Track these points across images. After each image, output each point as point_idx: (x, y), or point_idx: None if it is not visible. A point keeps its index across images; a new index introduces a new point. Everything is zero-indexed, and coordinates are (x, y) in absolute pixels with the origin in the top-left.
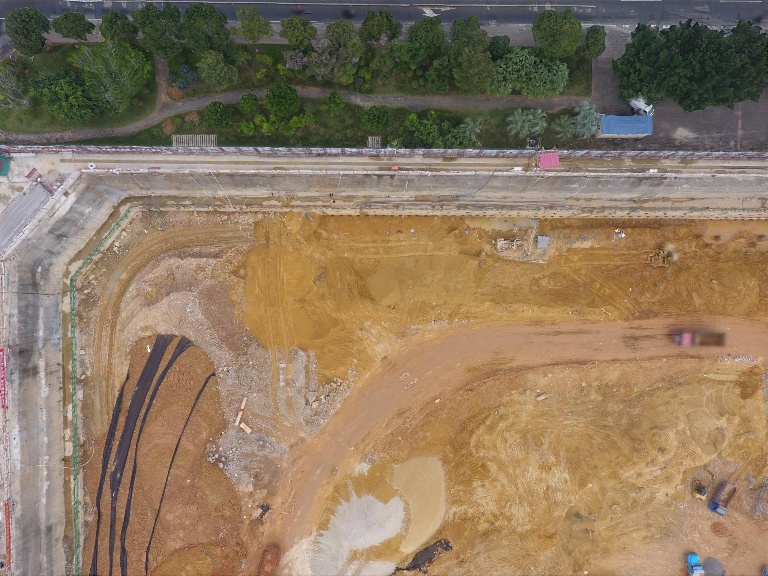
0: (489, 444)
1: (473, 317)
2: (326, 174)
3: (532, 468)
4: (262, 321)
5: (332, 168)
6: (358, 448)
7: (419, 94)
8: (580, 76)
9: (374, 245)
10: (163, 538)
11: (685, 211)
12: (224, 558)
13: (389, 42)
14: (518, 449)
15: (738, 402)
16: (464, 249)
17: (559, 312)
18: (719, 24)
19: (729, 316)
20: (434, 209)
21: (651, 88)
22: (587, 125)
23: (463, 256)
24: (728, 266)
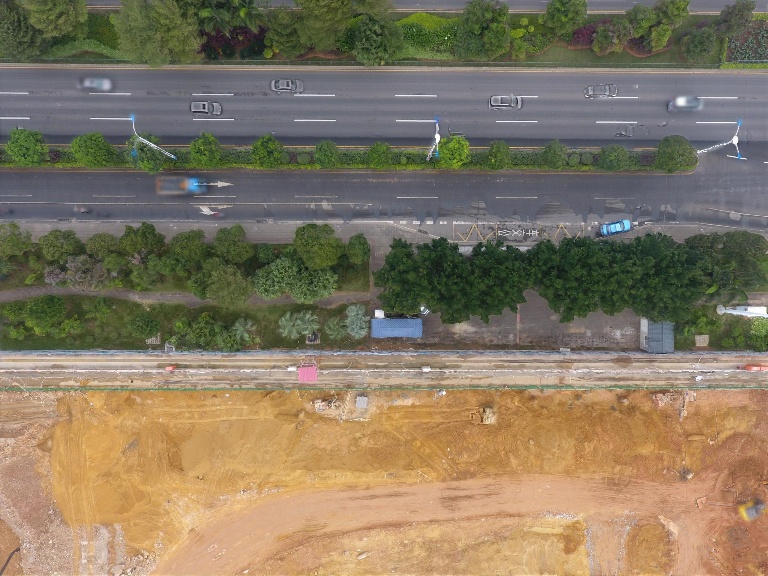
0: None
1: (283, 486)
2: (105, 371)
3: None
4: (64, 498)
5: (111, 365)
6: None
7: None
8: (354, 275)
9: (189, 410)
10: None
11: (483, 388)
12: None
13: (146, 258)
14: None
15: (561, 557)
16: (283, 409)
17: (373, 476)
18: (496, 220)
19: (548, 474)
20: (232, 388)
21: (404, 305)
22: (355, 330)
23: (278, 420)
24: (548, 423)
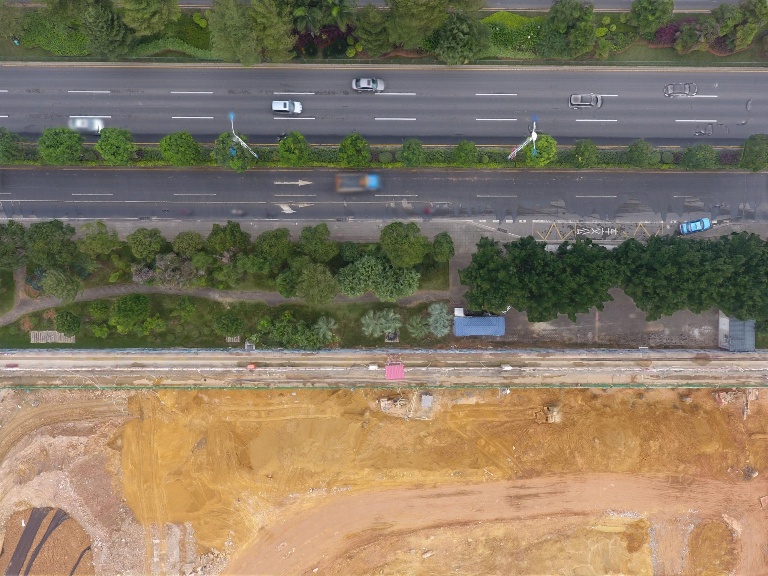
0: None
1: (352, 484)
2: None
3: None
4: (136, 497)
5: (191, 363)
6: None
7: (277, 290)
8: (435, 274)
9: (256, 408)
10: None
11: (555, 386)
12: None
13: (234, 257)
14: None
15: (625, 556)
16: (348, 408)
17: (440, 475)
18: (575, 218)
19: (613, 473)
20: (305, 387)
21: (493, 303)
22: (438, 328)
23: (345, 418)
24: (612, 422)
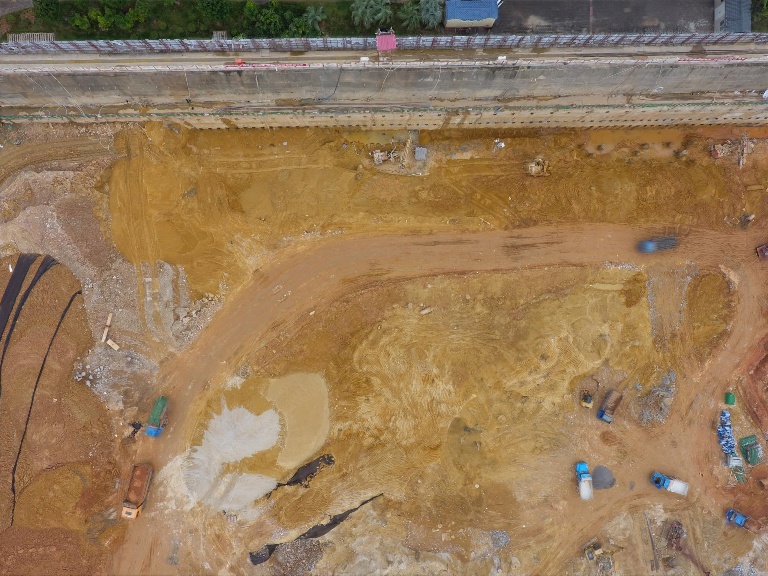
0: (372, 359)
1: (347, 228)
2: (170, 71)
3: (416, 381)
4: (125, 235)
5: (176, 65)
6: (230, 362)
7: None
8: None
9: (246, 159)
10: (30, 458)
11: (550, 109)
12: (95, 477)
13: None
14: (401, 362)
15: (623, 310)
16: (341, 163)
17: (436, 222)
18: None
19: (610, 223)
20: (296, 113)
21: None
22: (430, 10)
23: (338, 168)
24: (608, 173)
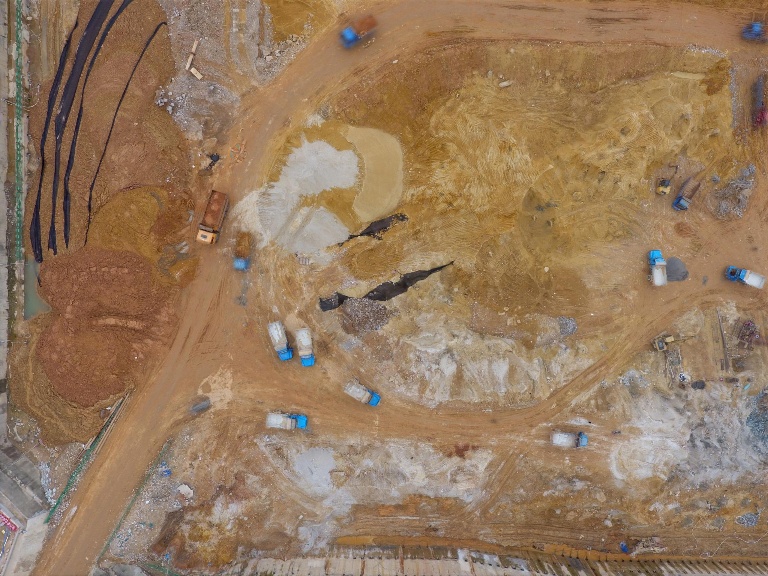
0: (449, 125)
1: None
2: None
3: (492, 149)
4: None
5: None
6: (312, 100)
7: None
8: None
9: None
10: (108, 178)
11: None
12: (171, 203)
13: None
14: (479, 129)
15: (704, 97)
16: None
17: None
18: None
19: (696, 4)
20: None
21: None
22: None
23: None
24: None
